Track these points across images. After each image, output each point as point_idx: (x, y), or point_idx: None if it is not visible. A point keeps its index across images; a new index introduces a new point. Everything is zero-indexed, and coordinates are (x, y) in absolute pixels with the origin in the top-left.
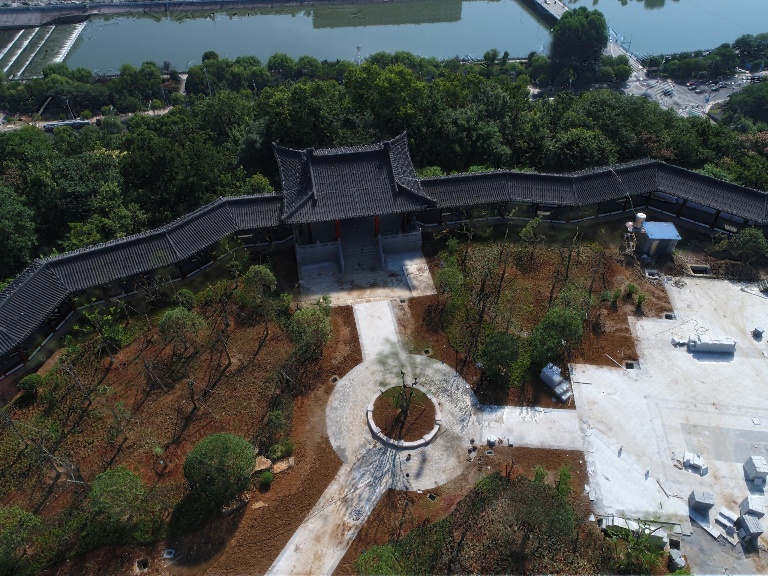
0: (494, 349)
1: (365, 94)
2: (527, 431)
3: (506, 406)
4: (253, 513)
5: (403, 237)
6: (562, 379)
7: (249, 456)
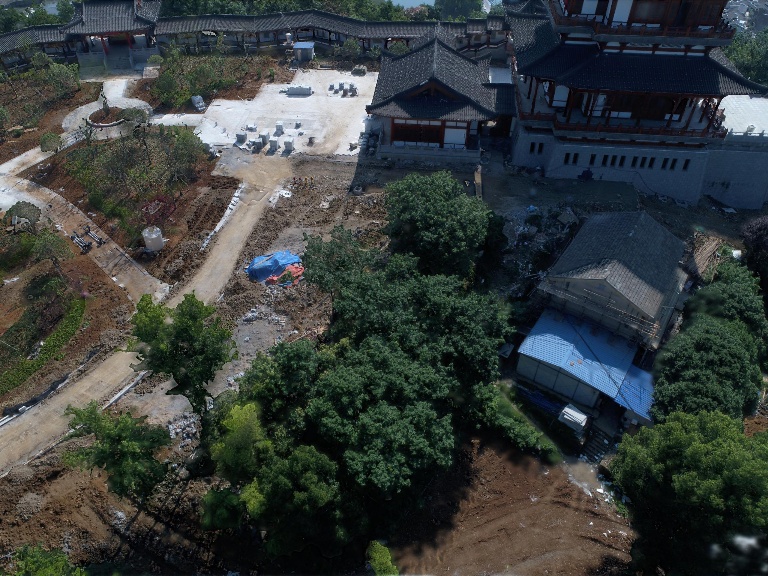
0: (159, 81)
1: None
2: (172, 121)
3: (167, 114)
4: (7, 144)
5: (146, 51)
6: (205, 104)
7: (2, 110)
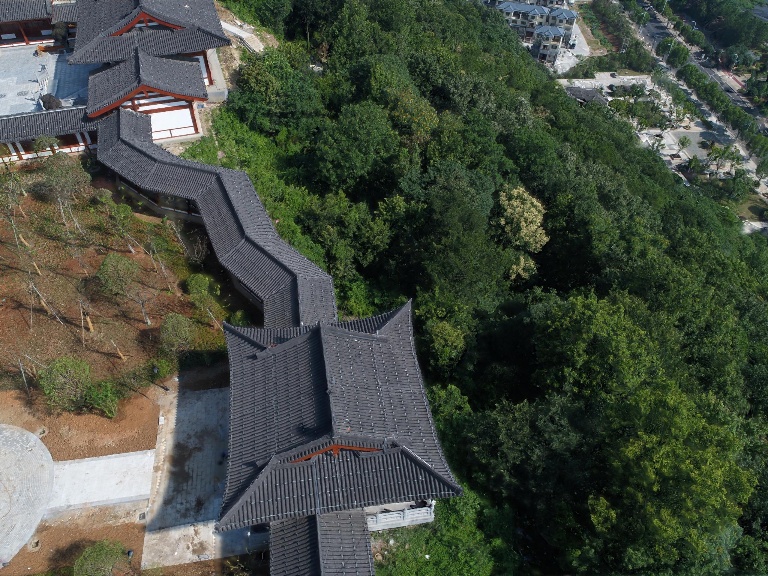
0: None
1: (613, 423)
2: None
3: None
4: None
5: None
6: None
7: None
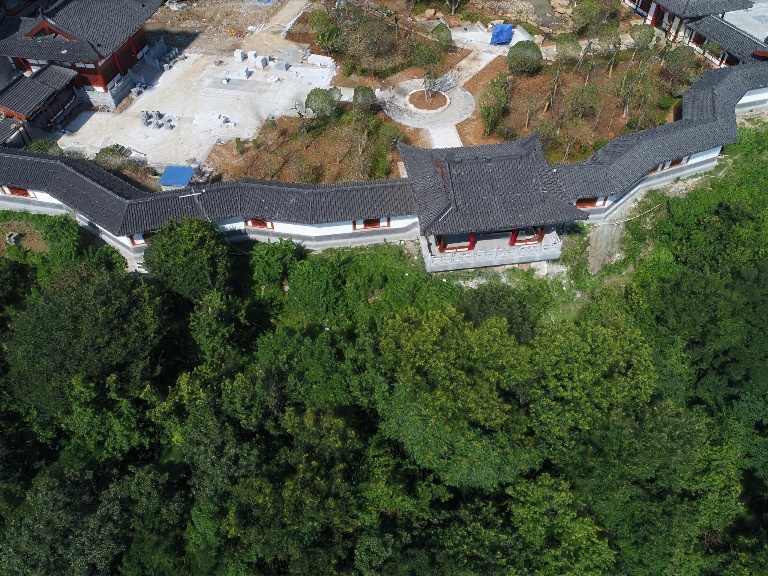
0: None
1: None
2: None
3: None
4: None
5: None
6: None
7: None
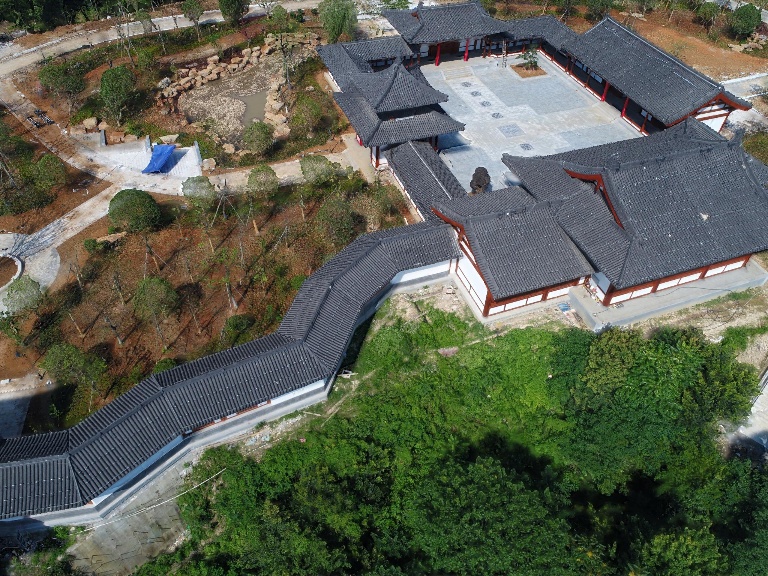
0: None
1: None
2: None
3: None
4: None
5: None
6: None
7: None
